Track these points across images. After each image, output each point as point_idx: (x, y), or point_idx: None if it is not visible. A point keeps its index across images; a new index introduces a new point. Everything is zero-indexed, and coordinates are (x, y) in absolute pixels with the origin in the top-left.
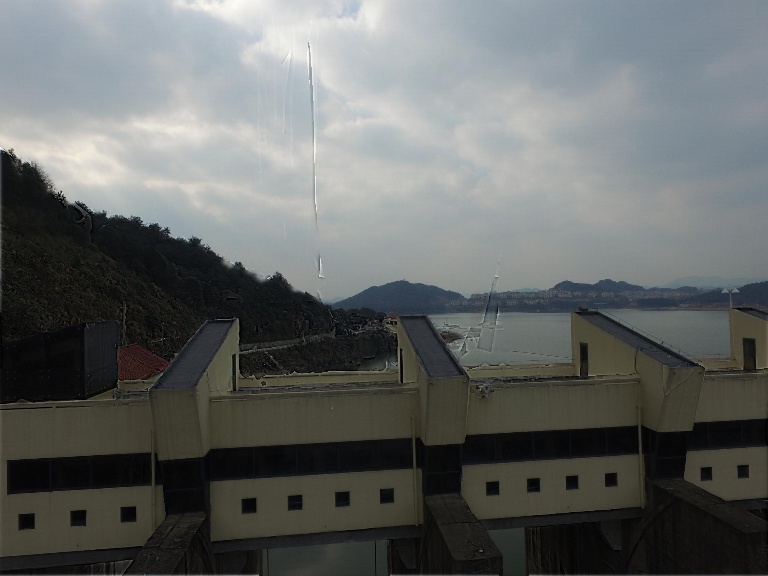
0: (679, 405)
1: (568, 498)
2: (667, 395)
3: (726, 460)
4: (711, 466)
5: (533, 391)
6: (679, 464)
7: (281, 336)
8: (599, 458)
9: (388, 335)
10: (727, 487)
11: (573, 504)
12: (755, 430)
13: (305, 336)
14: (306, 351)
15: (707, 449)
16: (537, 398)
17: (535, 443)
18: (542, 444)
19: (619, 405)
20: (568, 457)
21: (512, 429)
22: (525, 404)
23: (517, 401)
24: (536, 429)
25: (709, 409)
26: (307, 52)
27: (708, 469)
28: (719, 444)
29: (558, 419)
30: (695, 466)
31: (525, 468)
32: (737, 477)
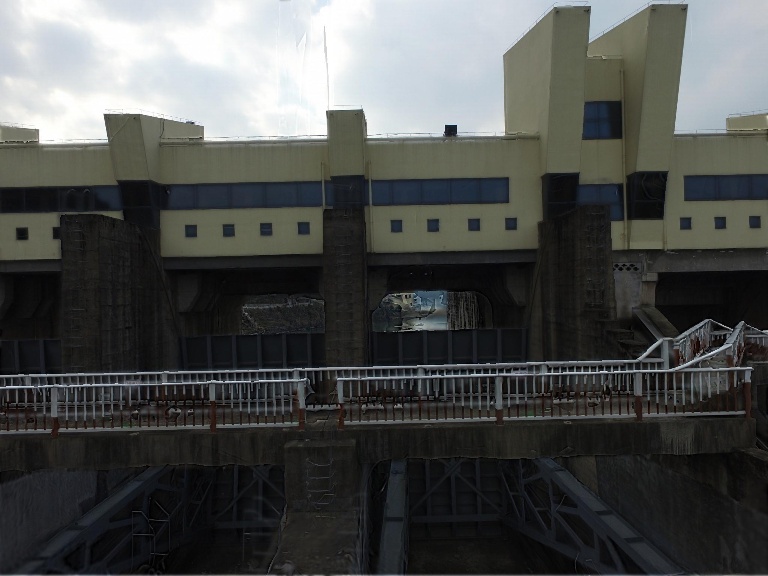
0: (127, 152)
1: (55, 246)
2: (111, 141)
3: (212, 219)
4: (196, 224)
5: (23, 151)
6: (150, 215)
7: (269, 300)
8: (85, 212)
9: (387, 305)
10: (212, 244)
11: (60, 252)
12: (249, 195)
13: (291, 299)
14: (290, 313)
15: (193, 209)
16: (27, 158)
17: (27, 198)
18: (37, 201)
19: (106, 166)
20: (57, 211)
21: (4, 184)
22: (16, 163)
23: (8, 160)
24: (26, 185)
25: (196, 172)
26: (323, 32)
27: (193, 227)
28: (208, 206)
29: (47, 177)
30: (180, 223)
31: (15, 218)
32: (222, 235)
